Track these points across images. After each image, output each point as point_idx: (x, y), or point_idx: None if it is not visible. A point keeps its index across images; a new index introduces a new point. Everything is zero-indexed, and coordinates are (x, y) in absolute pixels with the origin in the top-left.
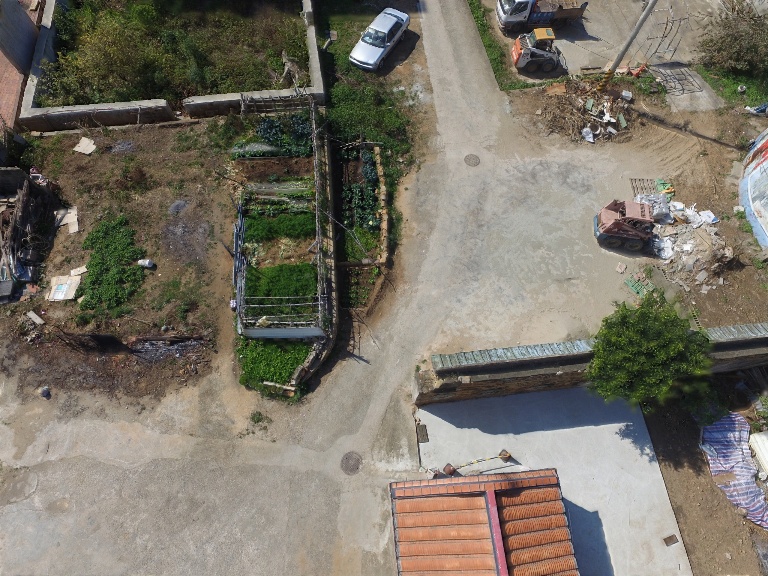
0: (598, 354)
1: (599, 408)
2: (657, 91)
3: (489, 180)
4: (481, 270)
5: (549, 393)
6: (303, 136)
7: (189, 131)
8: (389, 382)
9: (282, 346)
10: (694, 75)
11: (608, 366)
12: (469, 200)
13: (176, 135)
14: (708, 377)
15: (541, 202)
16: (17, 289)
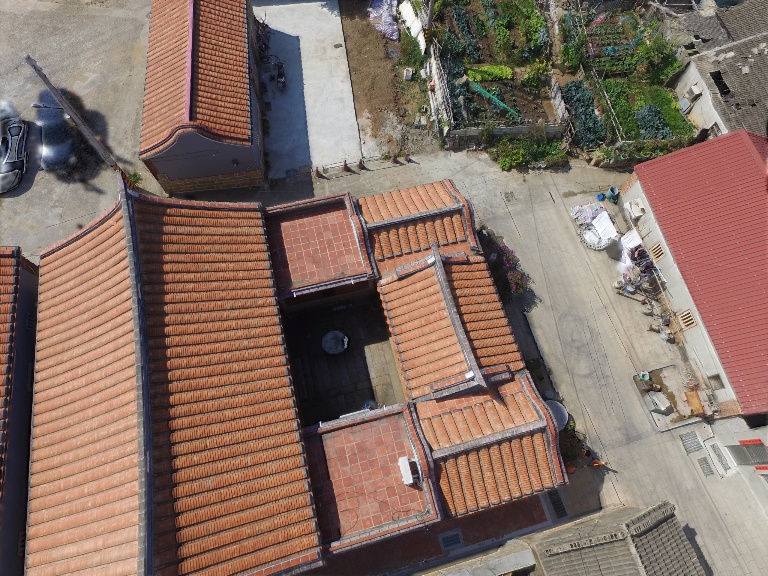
0: None
1: None
2: None
3: None
4: None
5: None
6: None
7: None
8: None
9: None
10: None
11: None
12: None
13: None
14: None
15: None
16: None
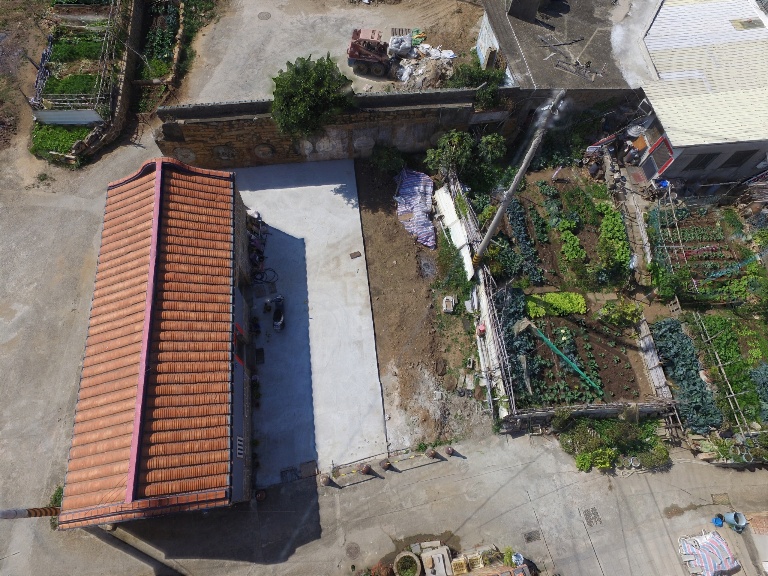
0: None
1: (322, 175)
2: None
3: (275, 29)
4: (252, 89)
5: (285, 166)
6: None
7: None
8: None
9: (70, 130)
10: None
11: None
12: (255, 43)
13: None
14: (414, 156)
15: (314, 44)
16: None
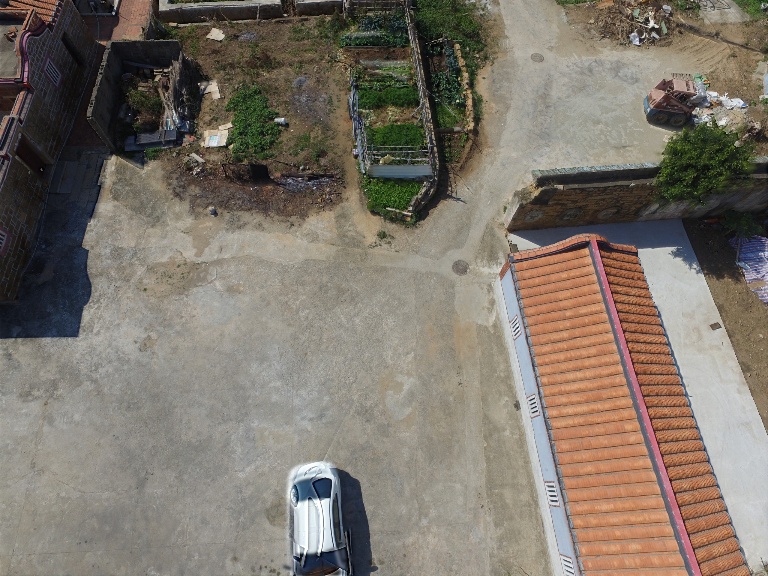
0: (665, 164)
1: (655, 236)
2: (692, 7)
3: (553, 73)
4: (551, 139)
5: (614, 225)
6: (398, 30)
7: (301, 26)
8: (483, 216)
9: (398, 184)
10: None
11: (675, 168)
12: (537, 87)
13: (290, 29)
14: None
15: (598, 90)
16: (178, 138)
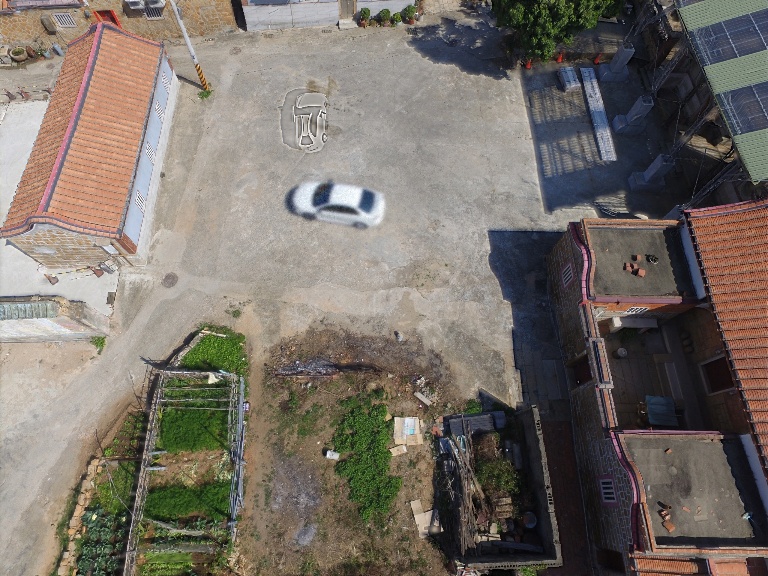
0: None
1: None
2: None
3: None
4: None
5: None
6: None
7: None
8: (127, 340)
9: (207, 367)
10: None
11: None
12: None
13: None
14: None
15: None
16: (449, 430)
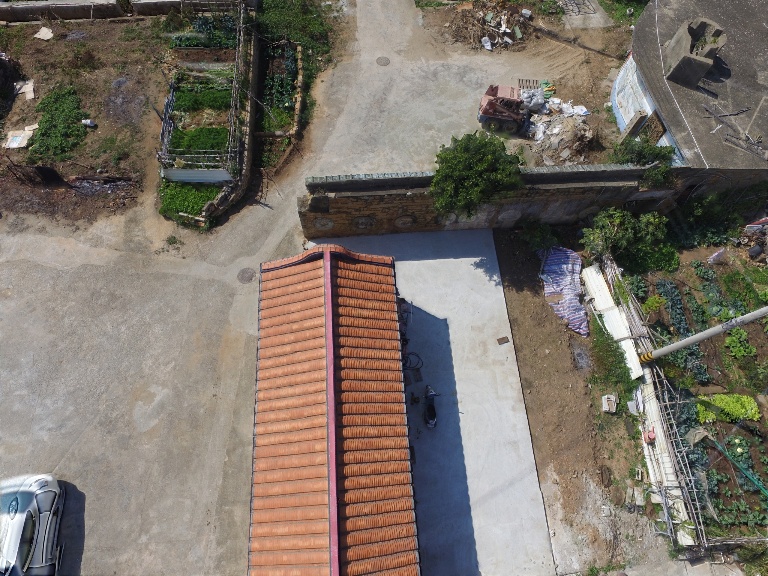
0: (436, 173)
1: (460, 246)
2: (555, 12)
3: (395, 77)
4: (378, 144)
5: (420, 234)
6: (233, 31)
7: (135, 26)
8: (287, 222)
9: (197, 188)
10: (592, 1)
11: (438, 177)
12: (375, 91)
13: (124, 28)
14: (556, 227)
15: (438, 95)
16: None
